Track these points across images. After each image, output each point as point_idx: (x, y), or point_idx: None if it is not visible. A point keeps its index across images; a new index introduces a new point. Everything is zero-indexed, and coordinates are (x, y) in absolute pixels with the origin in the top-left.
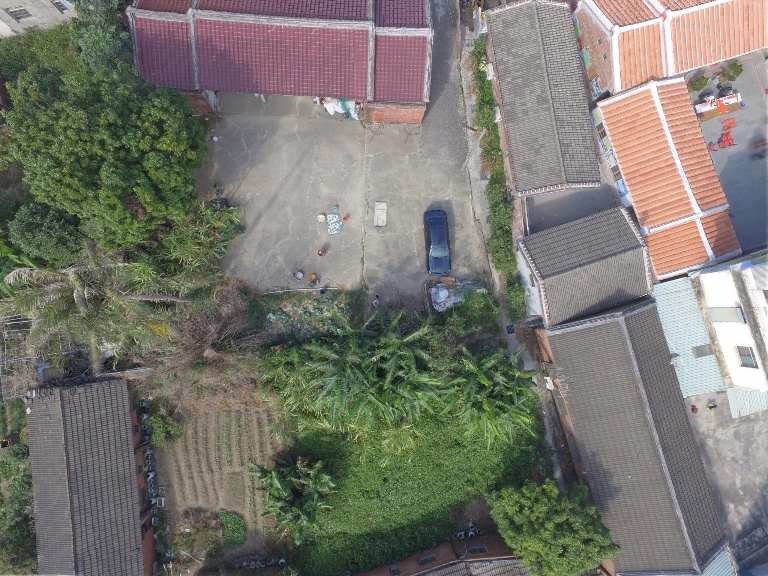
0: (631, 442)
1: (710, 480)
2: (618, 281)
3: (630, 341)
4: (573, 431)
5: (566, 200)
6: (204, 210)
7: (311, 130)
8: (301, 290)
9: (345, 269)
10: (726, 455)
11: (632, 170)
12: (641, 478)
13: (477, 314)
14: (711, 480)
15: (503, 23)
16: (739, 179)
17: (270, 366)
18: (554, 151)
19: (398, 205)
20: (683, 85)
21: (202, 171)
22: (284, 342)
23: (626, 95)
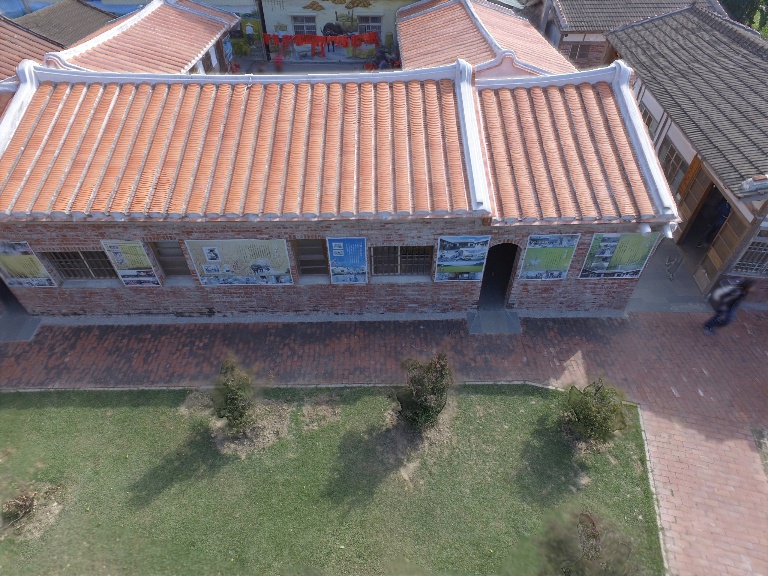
0: None
1: None
2: None
3: None
4: None
5: None
6: None
7: None
8: None
9: None
10: None
11: None
12: None
13: None
14: None
15: None
16: None
17: None
18: None
19: None
20: None
21: None
22: None
23: (554, 73)
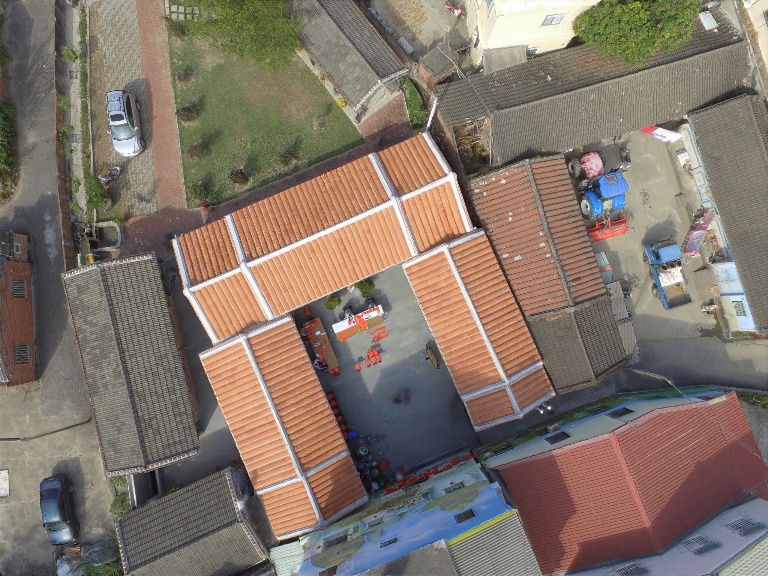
0: None
1: None
2: (222, 556)
3: None
4: None
5: (203, 442)
6: None
7: None
8: None
9: None
10: None
11: (238, 426)
12: None
13: None
14: None
15: (77, 288)
16: (394, 394)
17: None
18: (133, 430)
19: (21, 470)
20: (288, 326)
21: None
22: None
23: (221, 348)
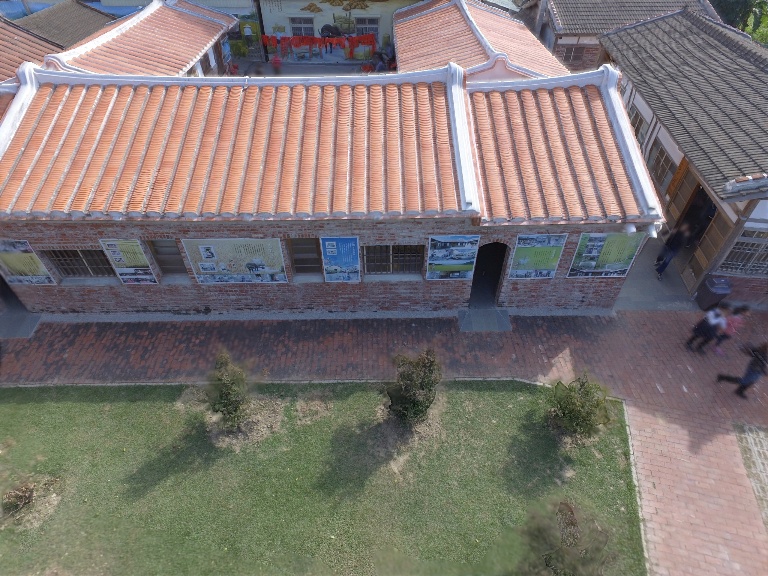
0: None
1: None
2: None
3: None
4: None
5: None
6: None
7: None
8: None
9: None
10: None
11: None
12: None
13: None
14: None
15: None
16: None
17: None
18: None
19: None
20: None
21: None
22: None
23: (546, 76)
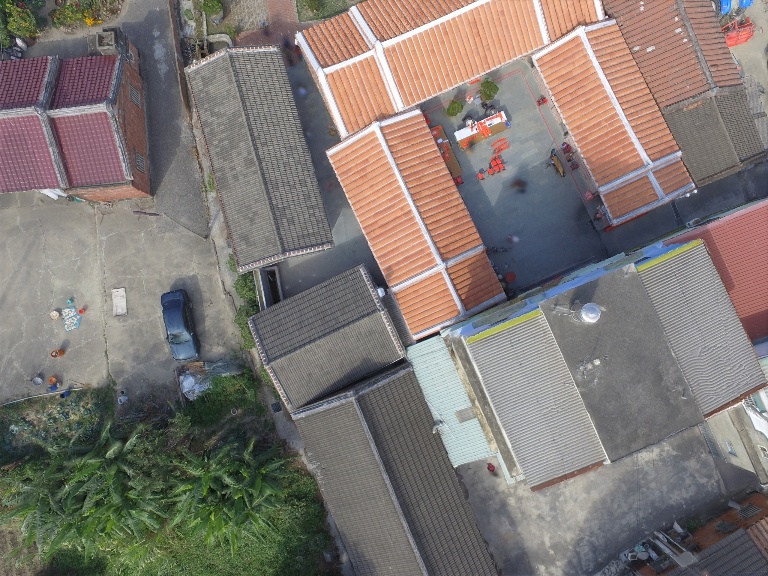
0: (386, 530)
1: (515, 542)
2: (361, 351)
3: (365, 423)
4: (334, 519)
5: (324, 257)
6: None
7: (35, 220)
8: (43, 395)
9: (88, 366)
10: (531, 513)
11: (370, 222)
12: (401, 568)
13: (233, 397)
14: (516, 542)
15: (202, 80)
16: (517, 206)
17: (7, 486)
18: (267, 218)
19: (138, 289)
20: (419, 118)
21: None
22: (23, 457)
23: (352, 140)
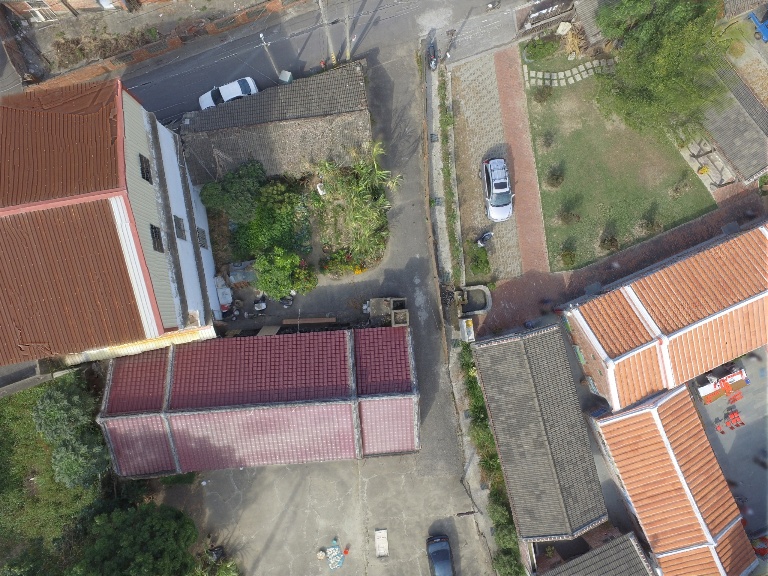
0: None
1: None
2: None
3: None
4: None
5: None
6: (200, 572)
7: None
8: None
9: None
10: None
11: (638, 492)
12: None
13: None
14: None
15: (491, 359)
16: (749, 454)
17: None
18: (556, 499)
19: (399, 530)
20: (685, 394)
21: (194, 520)
22: None
23: (626, 417)
